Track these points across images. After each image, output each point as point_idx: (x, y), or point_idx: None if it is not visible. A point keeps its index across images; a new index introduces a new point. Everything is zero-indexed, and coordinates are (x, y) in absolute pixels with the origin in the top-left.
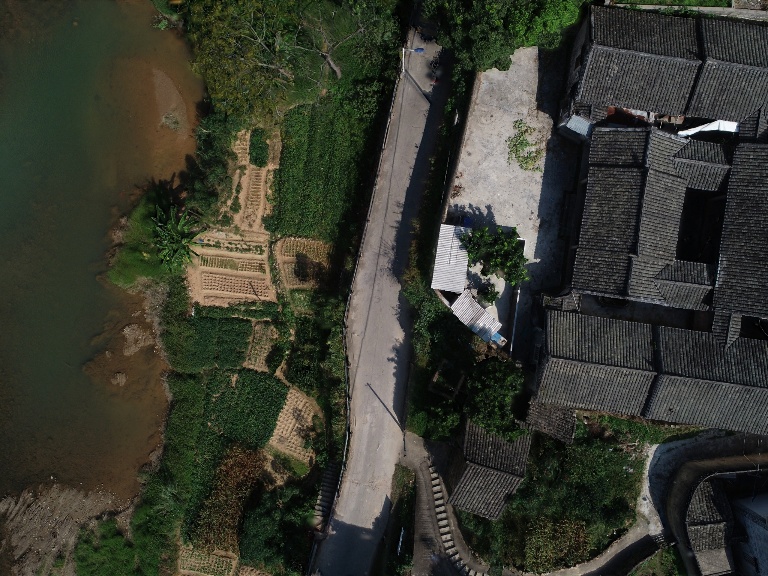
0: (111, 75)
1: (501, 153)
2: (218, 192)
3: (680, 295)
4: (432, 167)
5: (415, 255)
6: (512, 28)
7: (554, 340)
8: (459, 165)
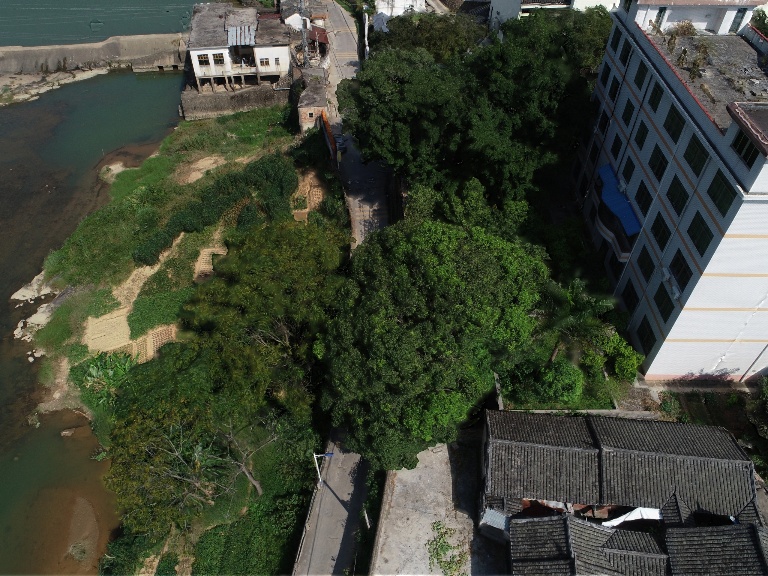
0: (32, 505)
1: (421, 558)
2: None
3: None
4: None
5: None
6: (406, 423)
7: None
8: (375, 574)
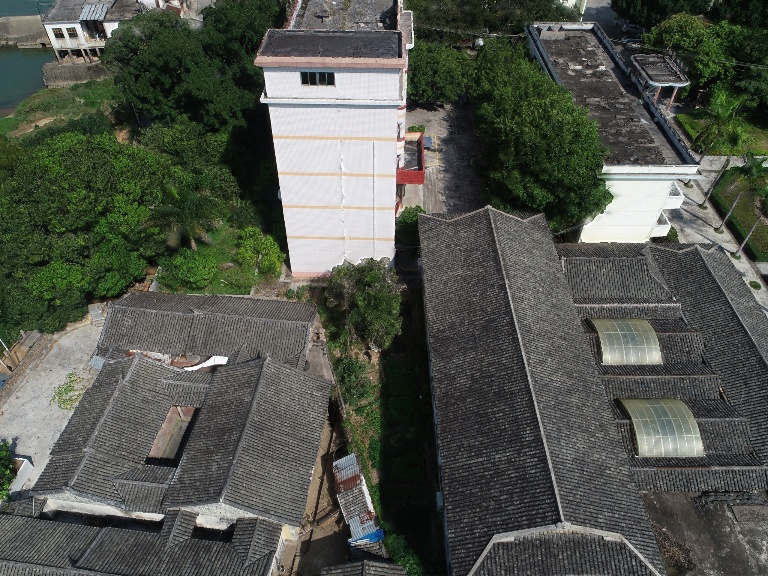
0: None
1: (46, 397)
2: None
3: (139, 496)
4: None
5: None
6: (29, 285)
7: None
8: (4, 406)
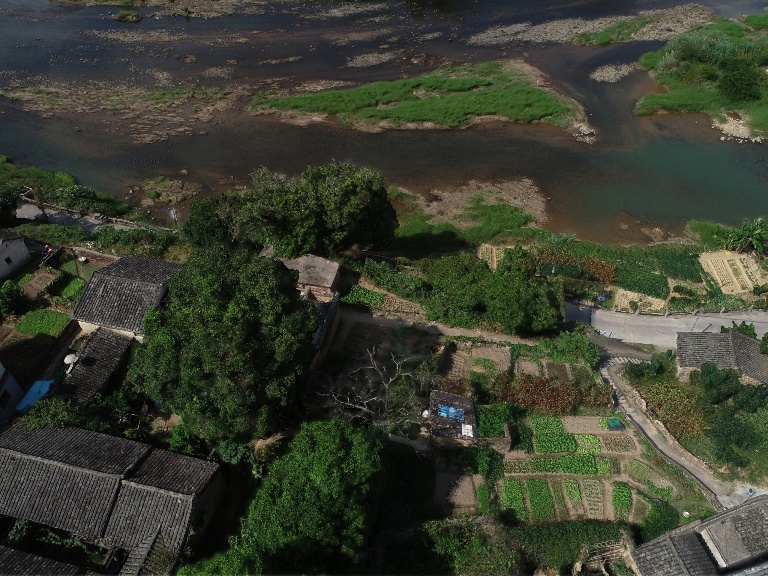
0: None
1: None
2: None
3: None
4: None
5: None
6: None
7: None
8: None
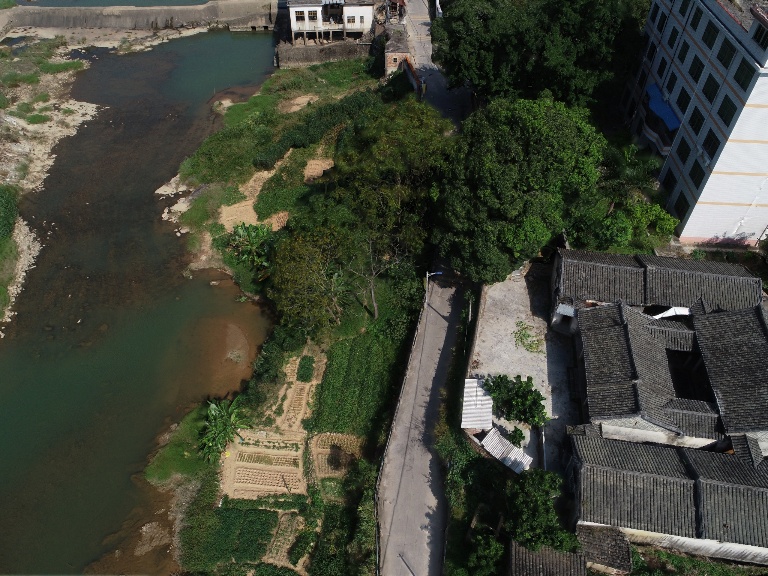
0: (194, 328)
1: (509, 341)
2: (266, 397)
3: (692, 424)
4: (454, 353)
5: (444, 414)
6: (503, 238)
7: (584, 454)
8: (476, 348)
